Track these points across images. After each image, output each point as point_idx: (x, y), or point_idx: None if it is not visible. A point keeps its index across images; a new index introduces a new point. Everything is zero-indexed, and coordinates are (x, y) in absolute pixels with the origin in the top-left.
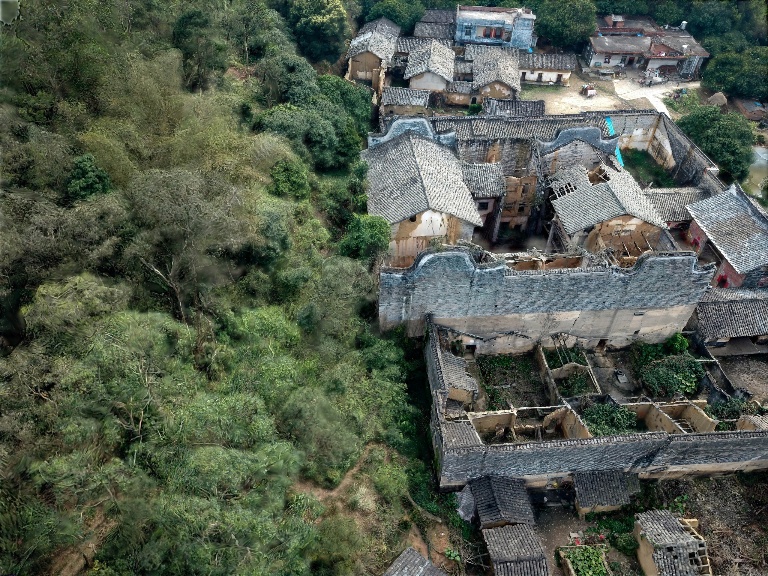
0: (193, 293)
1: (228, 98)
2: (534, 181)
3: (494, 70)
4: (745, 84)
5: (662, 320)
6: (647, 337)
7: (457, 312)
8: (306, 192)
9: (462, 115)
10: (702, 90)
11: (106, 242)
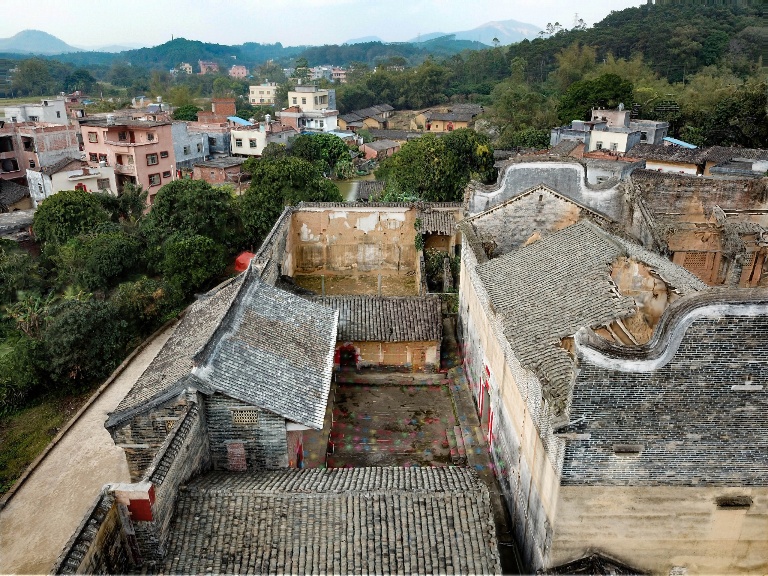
0: None
1: None
2: None
3: None
4: None
5: None
6: None
7: None
8: None
9: None
10: None
11: None
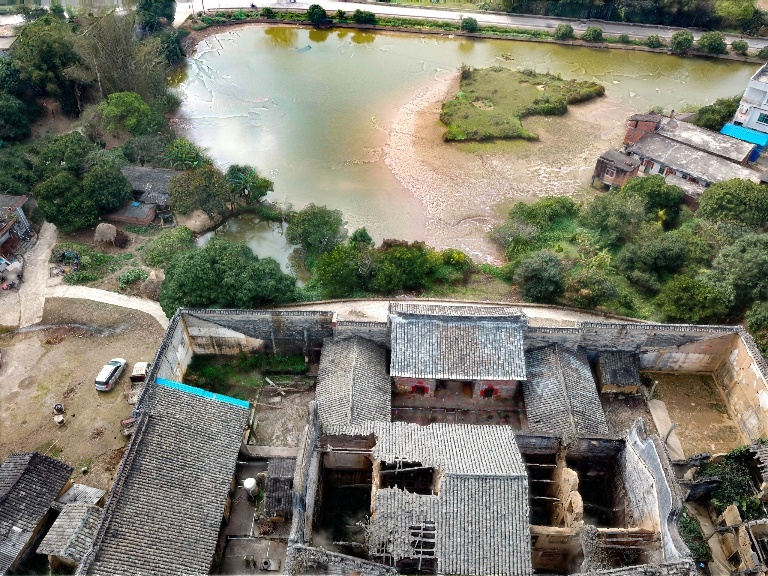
0: None
1: None
2: None
3: None
4: (109, 198)
5: None
6: None
7: None
8: None
9: None
10: (65, 234)
11: None
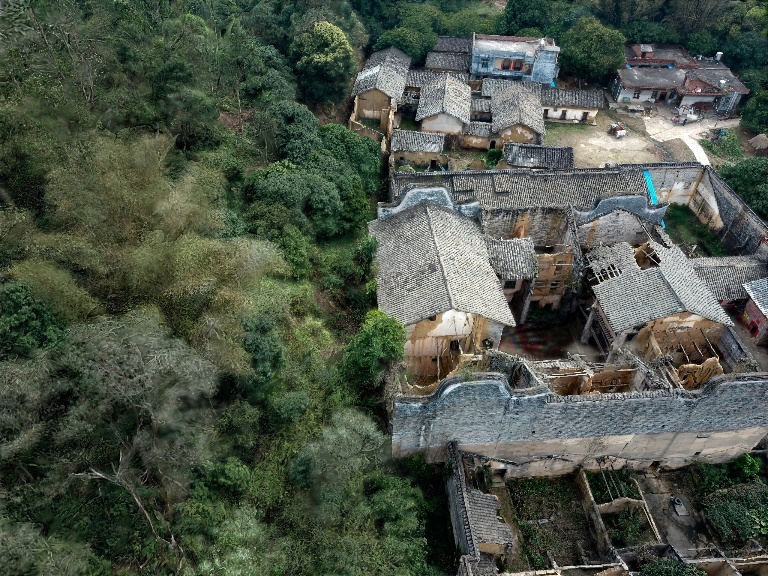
0: (156, 465)
1: (216, 159)
2: (570, 258)
3: (515, 111)
4: None
5: (729, 441)
6: (709, 457)
7: (486, 439)
8: (305, 271)
9: (481, 163)
10: (741, 129)
11: (29, 433)
